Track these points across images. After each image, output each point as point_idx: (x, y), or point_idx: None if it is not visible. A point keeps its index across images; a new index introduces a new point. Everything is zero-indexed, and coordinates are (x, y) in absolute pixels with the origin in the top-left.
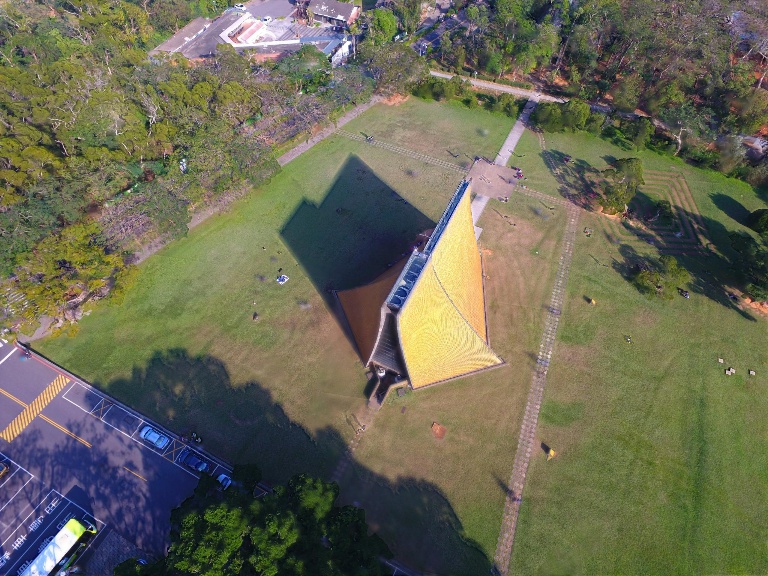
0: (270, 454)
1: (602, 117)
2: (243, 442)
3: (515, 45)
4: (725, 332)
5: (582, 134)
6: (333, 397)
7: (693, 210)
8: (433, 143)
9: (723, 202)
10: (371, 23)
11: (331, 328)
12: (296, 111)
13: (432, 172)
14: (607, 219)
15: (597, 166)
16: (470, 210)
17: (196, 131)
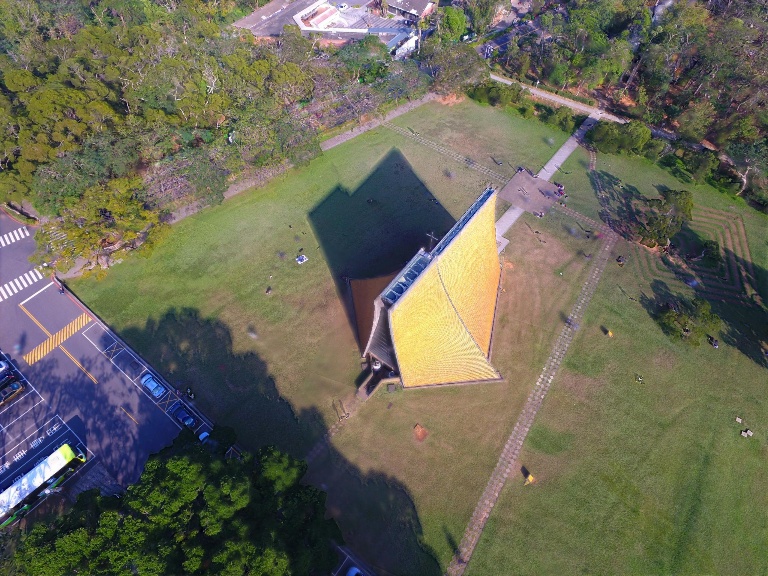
0: (254, 422)
1: (662, 144)
2: (231, 406)
3: (583, 58)
4: (751, 391)
5: (638, 159)
6: (325, 380)
7: (745, 256)
8: (478, 148)
9: None
10: (440, 20)
11: (337, 314)
12: (347, 98)
13: (471, 176)
14: (645, 251)
15: (647, 194)
16: (494, 219)
17: (247, 106)
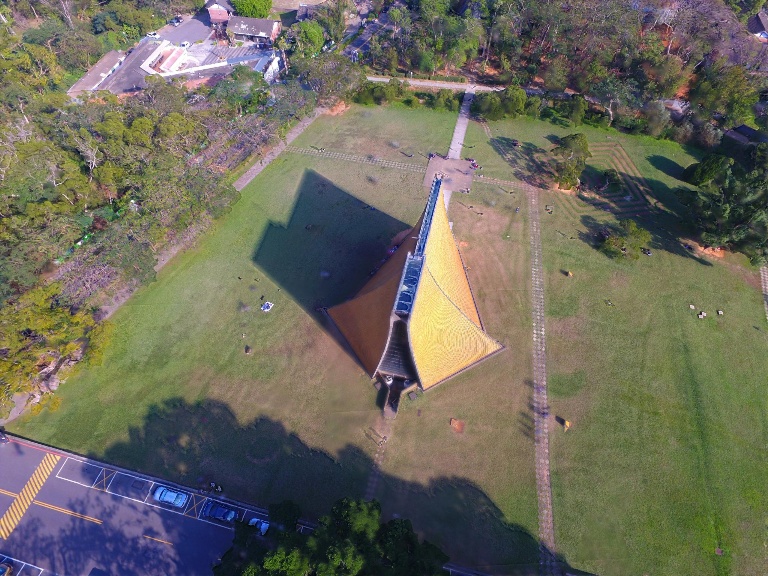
0: (297, 486)
1: (539, 100)
2: (266, 480)
3: (444, 42)
4: (689, 280)
5: (522, 118)
6: (347, 415)
7: (636, 174)
8: (385, 147)
9: (659, 162)
10: (298, 36)
11: (328, 346)
12: (243, 134)
13: (391, 175)
14: (563, 194)
15: (543, 146)
16: None
17: (145, 169)
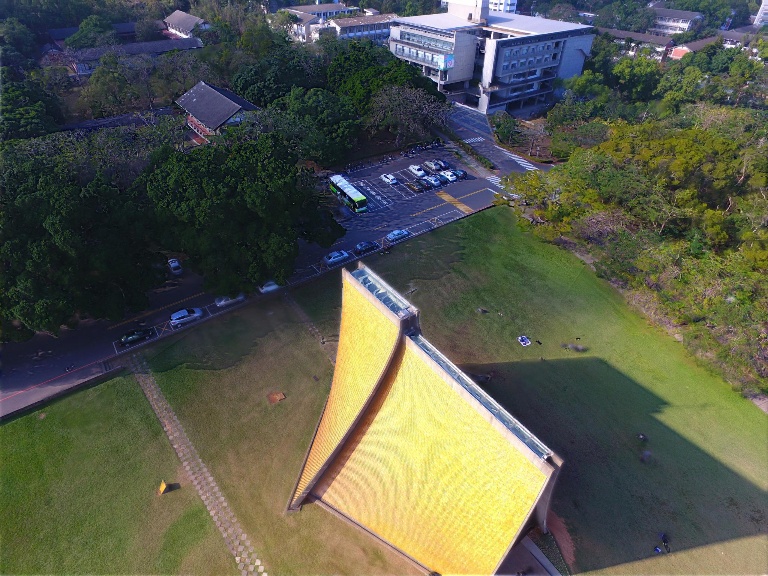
0: None
1: None
2: None
3: None
4: None
5: None
6: None
7: None
8: None
9: None
10: None
11: None
12: None
13: None
14: None
15: None
16: (524, 514)
17: None
